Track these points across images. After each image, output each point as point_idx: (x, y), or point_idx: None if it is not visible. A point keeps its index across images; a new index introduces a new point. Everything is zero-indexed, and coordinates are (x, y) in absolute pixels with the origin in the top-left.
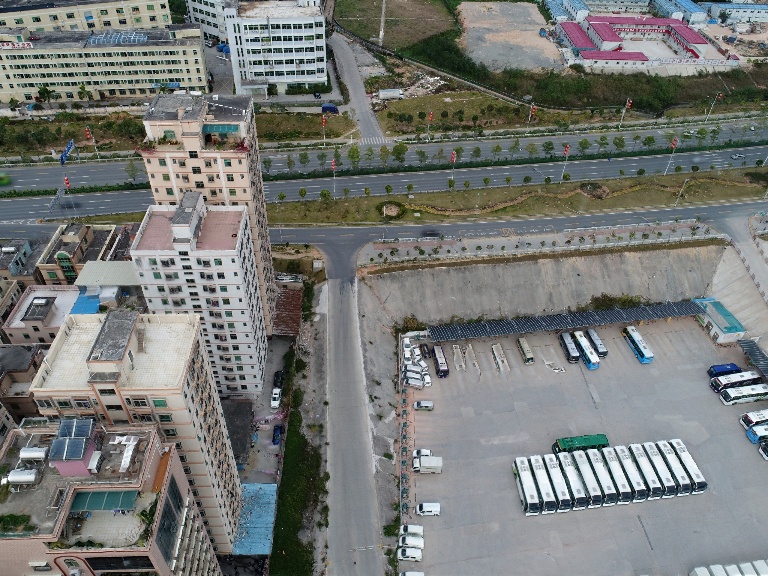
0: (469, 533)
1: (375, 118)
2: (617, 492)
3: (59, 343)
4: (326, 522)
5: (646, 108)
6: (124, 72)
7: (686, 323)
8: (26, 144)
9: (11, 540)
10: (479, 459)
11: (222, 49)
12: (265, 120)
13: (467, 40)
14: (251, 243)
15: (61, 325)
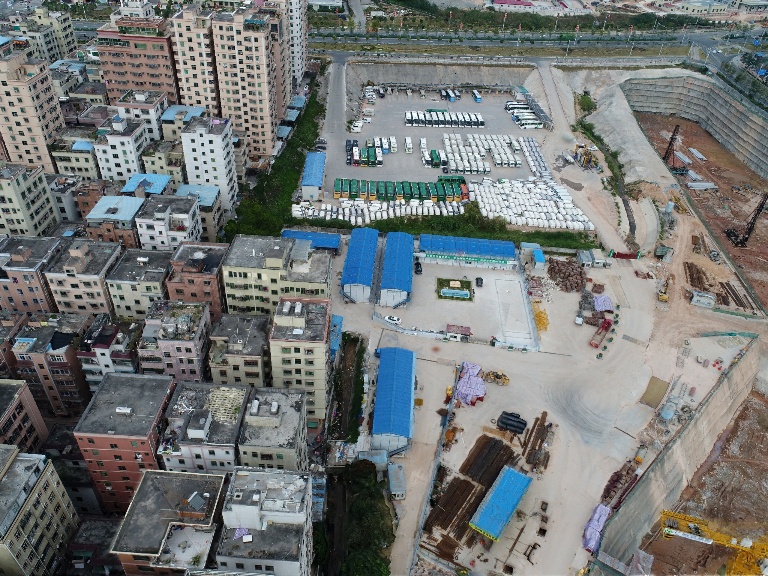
0: None
1: None
2: (445, 120)
3: None
4: (324, 118)
5: (525, 27)
6: None
7: (505, 95)
8: None
9: None
10: (391, 115)
11: None
12: None
13: None
14: None
15: None
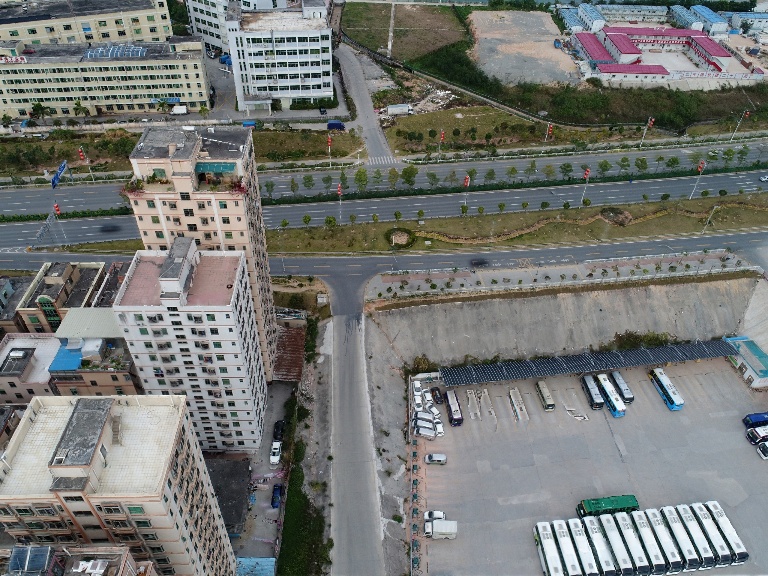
0: None
1: (383, 135)
2: (650, 564)
3: (22, 433)
4: None
5: (667, 125)
6: (122, 87)
7: (717, 364)
8: (18, 164)
9: None
10: (497, 522)
11: (225, 61)
12: (268, 138)
13: (479, 52)
14: (249, 290)
15: None
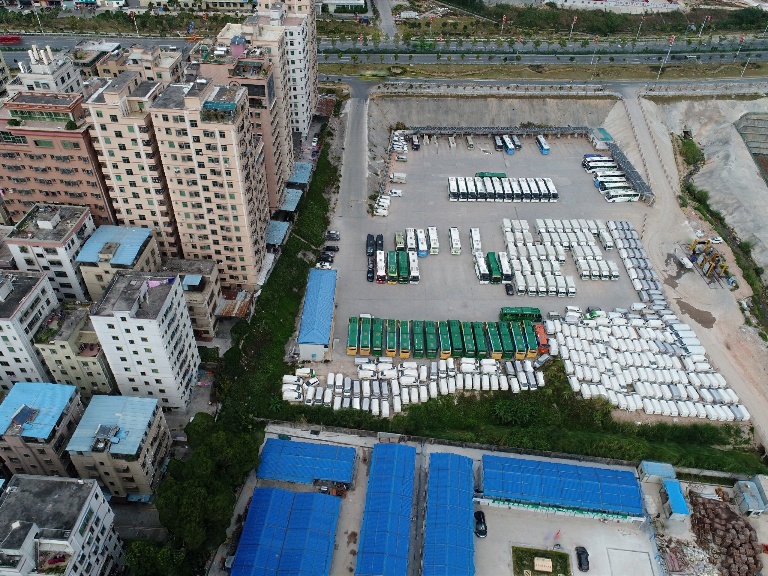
0: (416, 204)
1: (396, 28)
2: (503, 193)
3: (225, 30)
4: (338, 191)
5: (596, 32)
6: None
7: (580, 140)
8: None
9: (218, 65)
10: (429, 181)
11: None
12: None
13: None
14: None
15: None
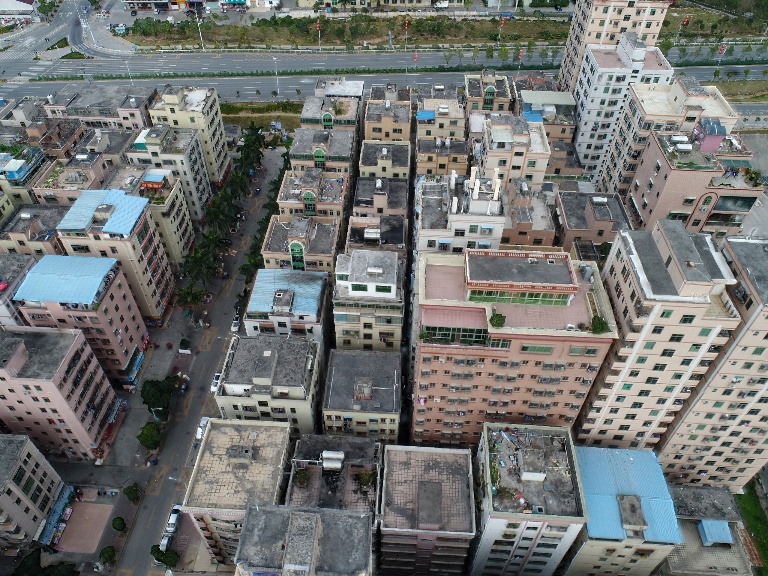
0: None
1: None
2: None
3: None
4: None
5: None
6: None
7: None
8: (342, 37)
9: (700, 172)
10: None
11: None
12: None
13: None
14: None
15: (633, 87)
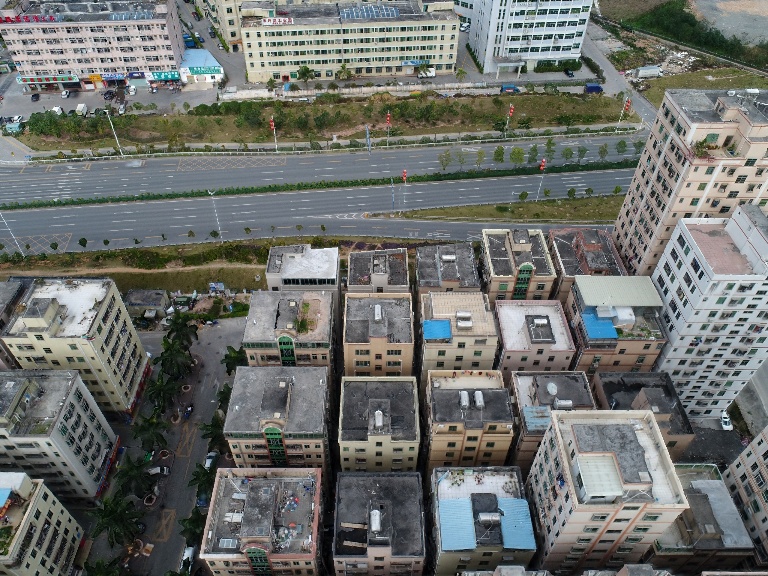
0: None
1: (644, 99)
2: None
3: None
4: None
5: None
6: (377, 49)
7: None
8: (304, 129)
9: None
10: None
11: None
12: None
13: (700, 10)
14: None
15: None
